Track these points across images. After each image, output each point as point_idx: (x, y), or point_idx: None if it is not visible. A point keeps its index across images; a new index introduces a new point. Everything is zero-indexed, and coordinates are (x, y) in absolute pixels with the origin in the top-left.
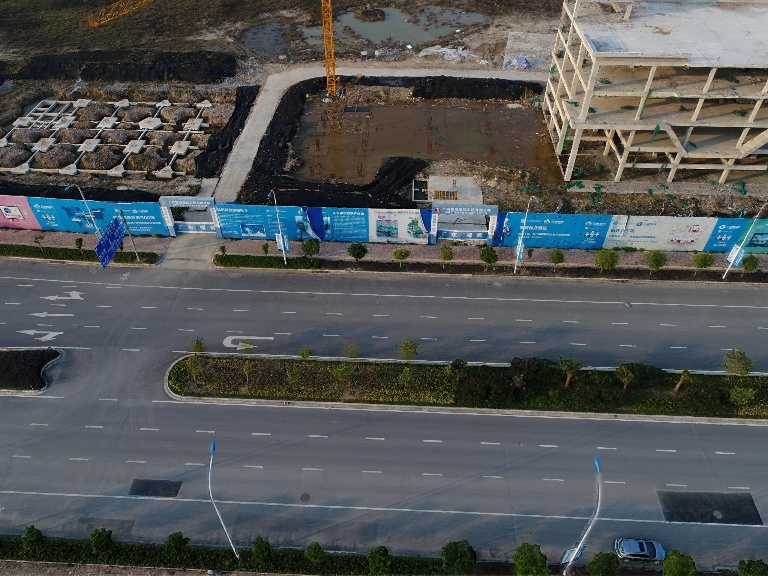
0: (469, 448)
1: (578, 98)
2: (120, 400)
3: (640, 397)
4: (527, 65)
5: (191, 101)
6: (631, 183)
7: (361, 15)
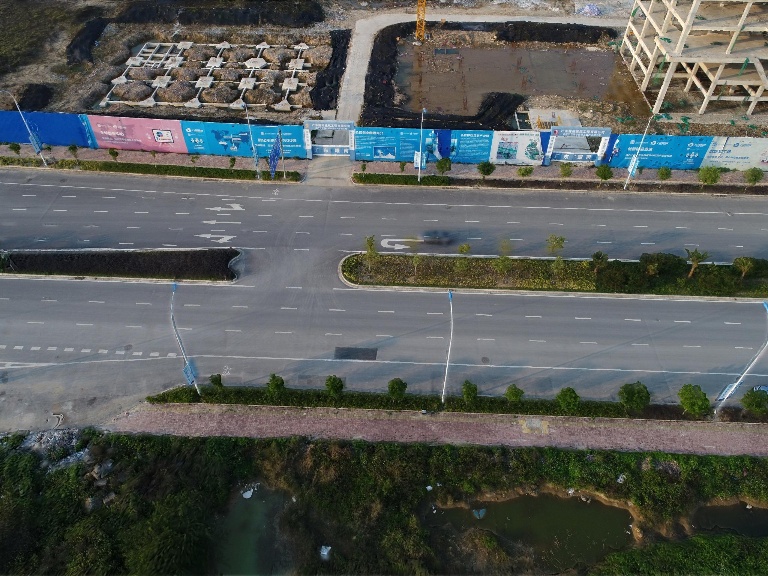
0: (615, 323)
1: (669, 35)
2: (305, 288)
3: (755, 284)
4: (598, 12)
5: (288, 44)
6: (714, 115)
7: None
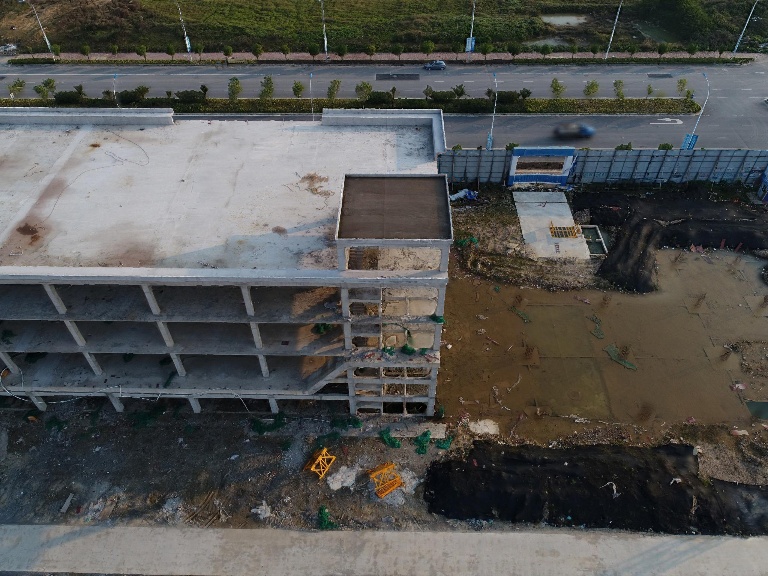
0: None
1: None
2: None
3: None
4: None
5: None
6: None
7: None
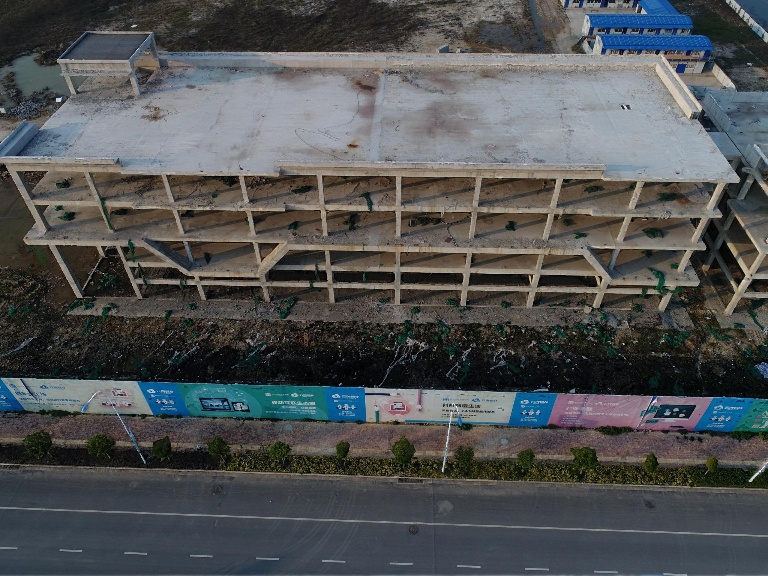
0: None
1: None
2: None
3: None
4: None
5: None
6: (156, 301)
7: (40, 57)
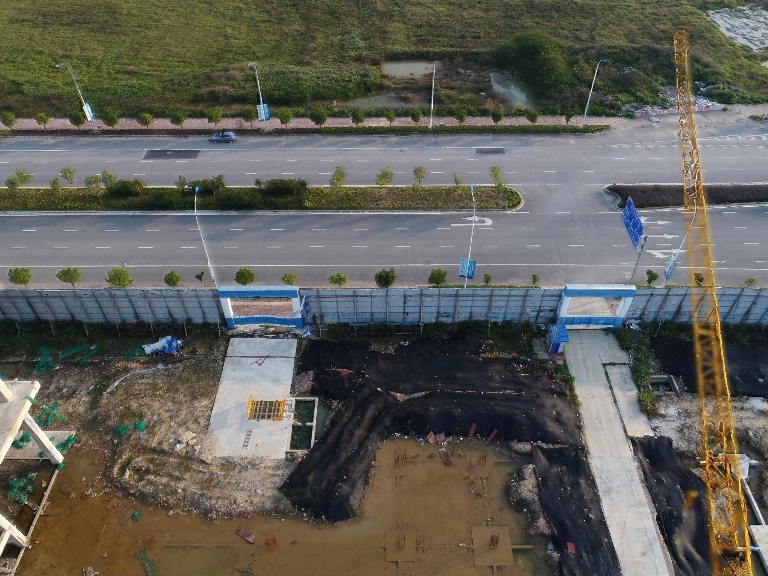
0: (302, 171)
1: None
2: (545, 184)
3: None
4: None
5: None
6: None
7: None
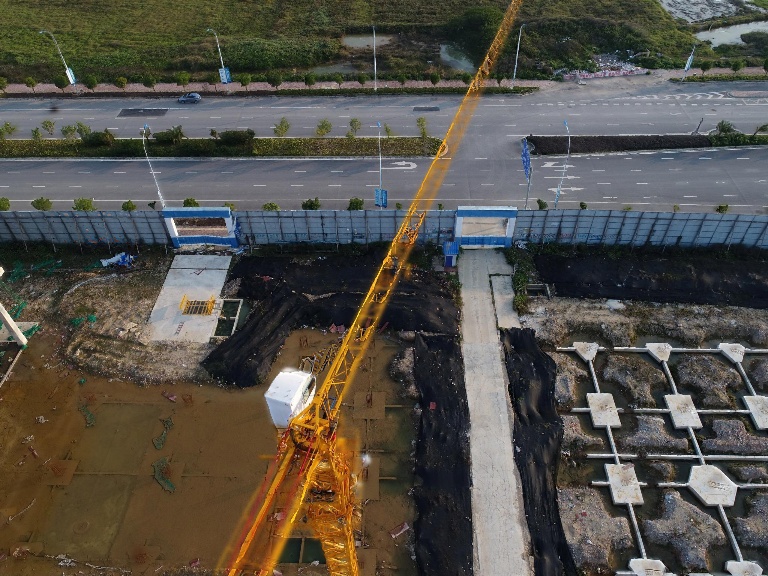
0: (256, 126)
1: None
2: (470, 136)
3: None
4: None
5: None
6: None
7: None
